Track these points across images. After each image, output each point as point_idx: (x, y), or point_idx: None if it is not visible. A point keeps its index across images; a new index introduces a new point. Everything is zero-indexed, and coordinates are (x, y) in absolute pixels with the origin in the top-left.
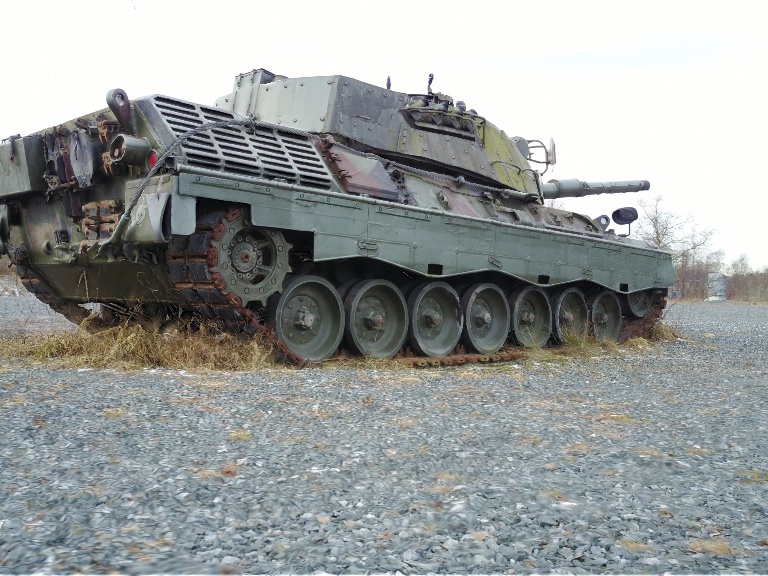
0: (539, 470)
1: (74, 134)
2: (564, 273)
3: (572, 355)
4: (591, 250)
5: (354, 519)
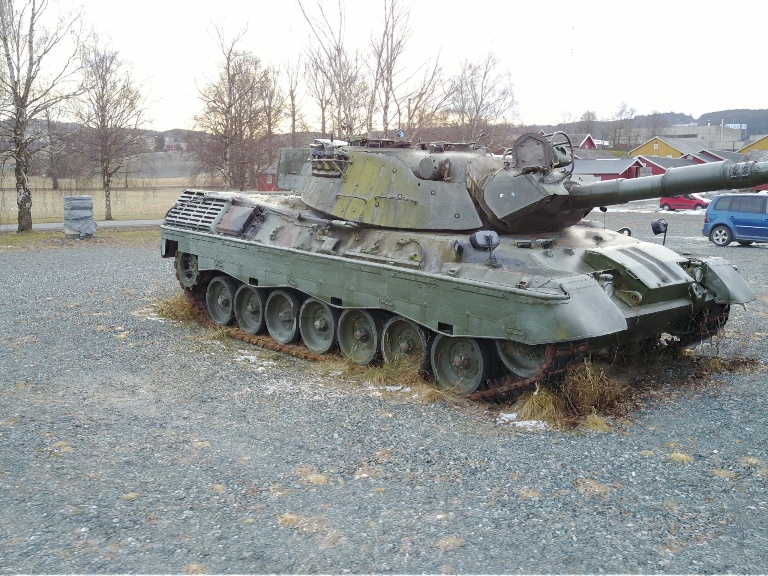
0: None
1: None
2: (358, 299)
3: None
4: (392, 280)
5: None
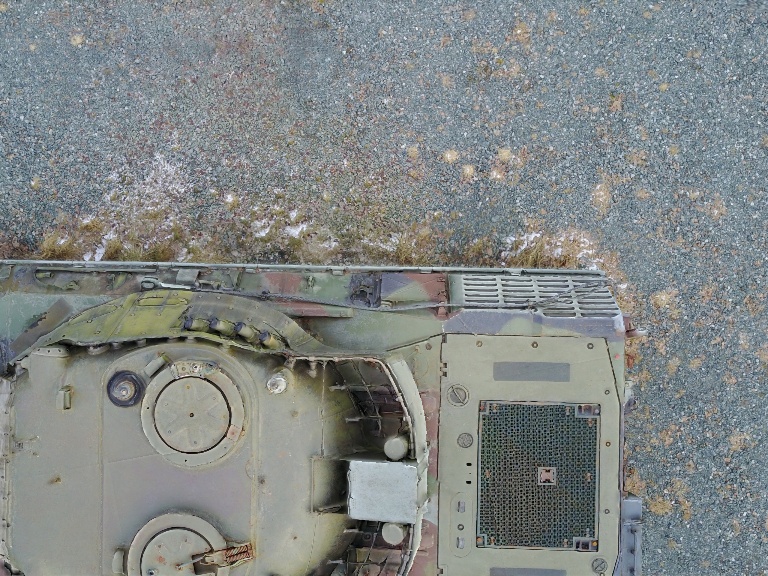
0: (620, 2)
1: None
2: None
3: (171, 255)
4: None
5: (690, 6)
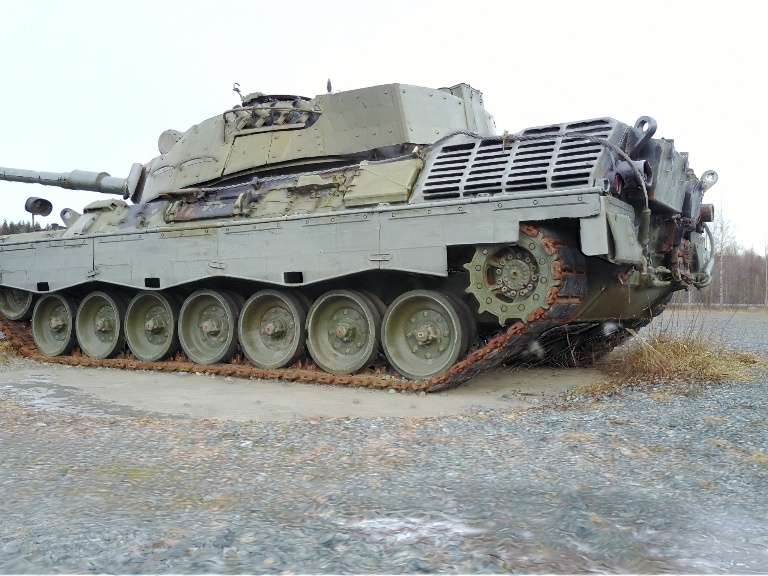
0: None
1: (702, 183)
2: None
3: None
4: None
5: None
